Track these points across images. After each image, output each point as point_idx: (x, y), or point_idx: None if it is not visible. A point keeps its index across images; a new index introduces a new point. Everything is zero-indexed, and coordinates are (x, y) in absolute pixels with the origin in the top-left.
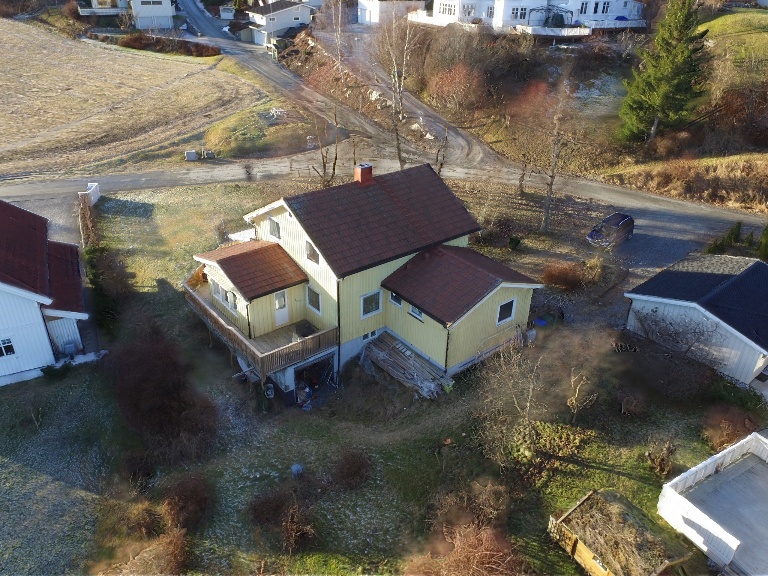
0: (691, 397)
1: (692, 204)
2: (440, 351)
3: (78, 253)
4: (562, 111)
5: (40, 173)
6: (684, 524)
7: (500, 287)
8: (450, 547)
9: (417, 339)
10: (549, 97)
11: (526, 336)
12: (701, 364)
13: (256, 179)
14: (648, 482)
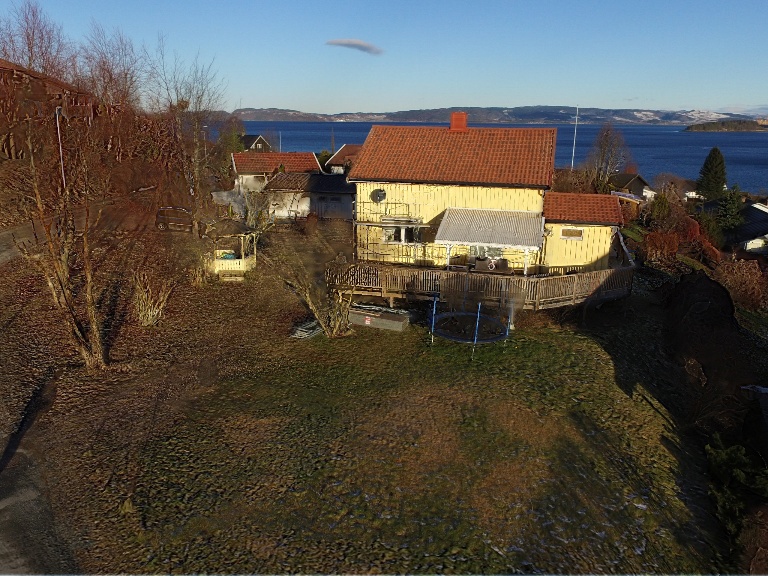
0: None
1: None
2: None
3: None
4: None
5: None
6: None
7: None
8: None
9: None
10: None
11: None
12: None
13: (21, 503)
14: None
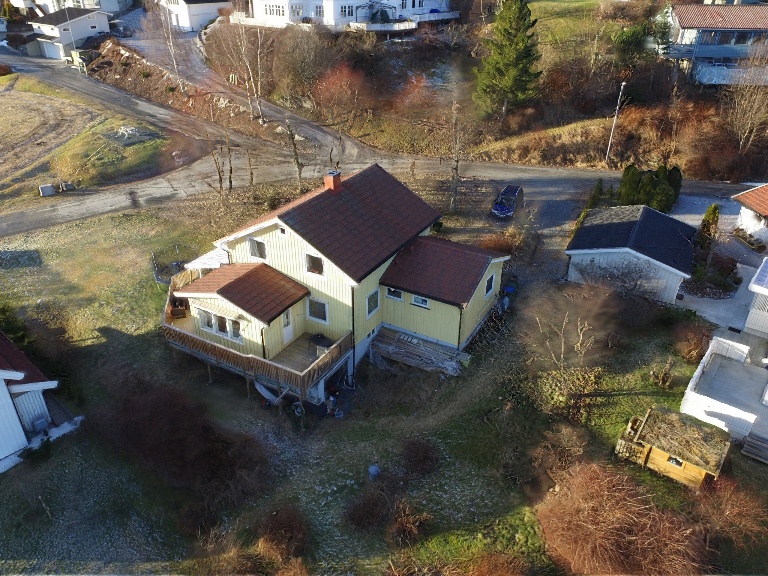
0: None
1: (552, 169)
2: (451, 332)
3: None
4: (419, 100)
5: None
6: (707, 416)
7: None
8: (543, 492)
9: (422, 326)
10: (400, 88)
11: (503, 303)
12: None
13: (141, 205)
14: (660, 394)
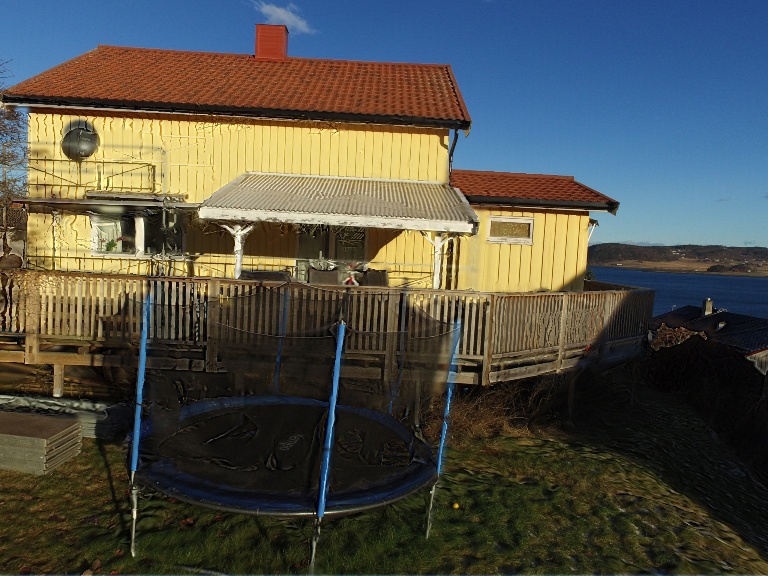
0: None
1: None
2: None
3: None
4: None
5: None
6: None
7: None
8: None
9: None
10: None
11: None
12: None
13: None
14: None
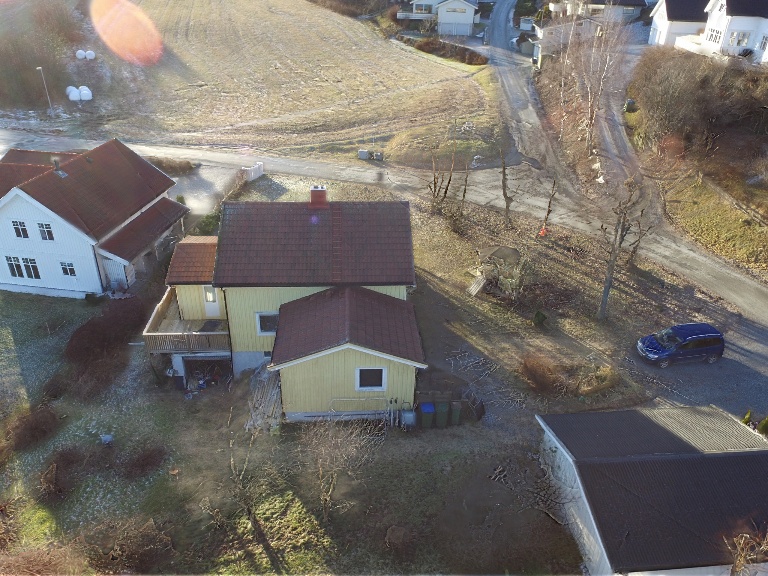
0: (492, 570)
1: None
2: None
3: (202, 215)
4: None
5: (250, 147)
6: None
7: (346, 347)
8: None
9: None
10: None
11: (400, 415)
12: (573, 544)
13: (389, 187)
14: None
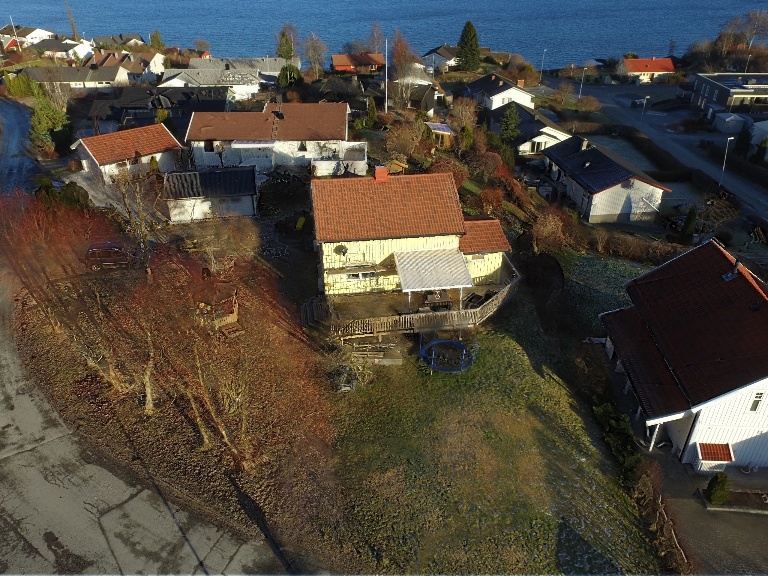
0: None
1: None
2: None
3: None
4: None
5: None
6: None
7: None
8: None
9: None
10: None
11: None
12: None
13: None
14: None
